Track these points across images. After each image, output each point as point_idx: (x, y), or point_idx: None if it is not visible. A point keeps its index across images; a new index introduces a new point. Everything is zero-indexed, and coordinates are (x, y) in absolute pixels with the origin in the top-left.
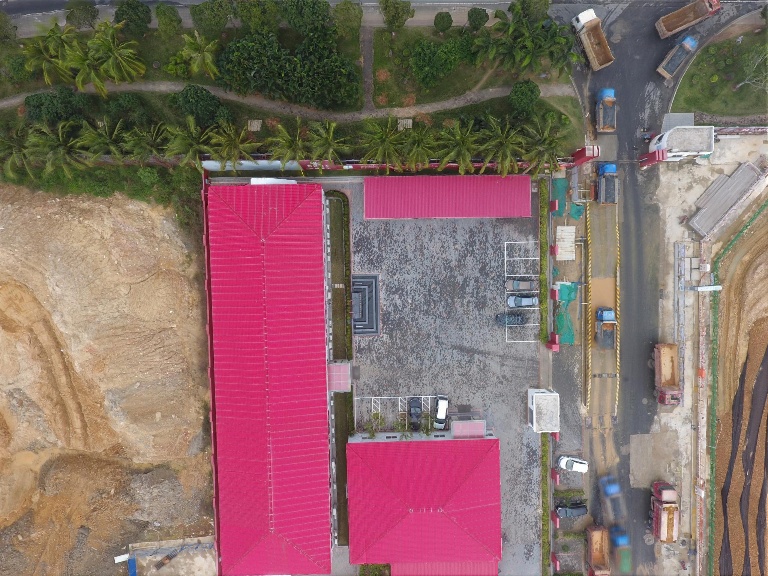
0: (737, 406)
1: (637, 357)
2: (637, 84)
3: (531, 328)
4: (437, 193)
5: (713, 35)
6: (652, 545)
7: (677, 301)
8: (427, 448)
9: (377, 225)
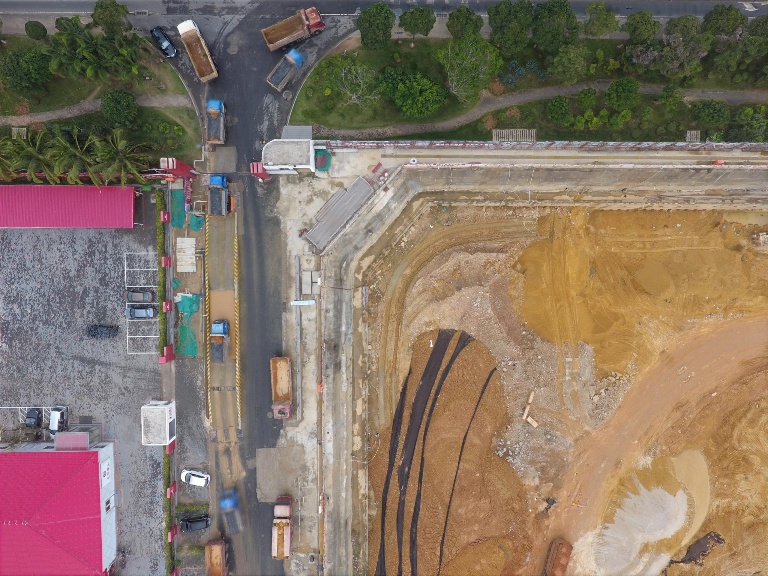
0: (397, 420)
1: (261, 370)
2: (255, 96)
3: (153, 340)
4: (39, 203)
5: (331, 48)
6: (281, 560)
7: (299, 315)
8: (24, 460)
9: None
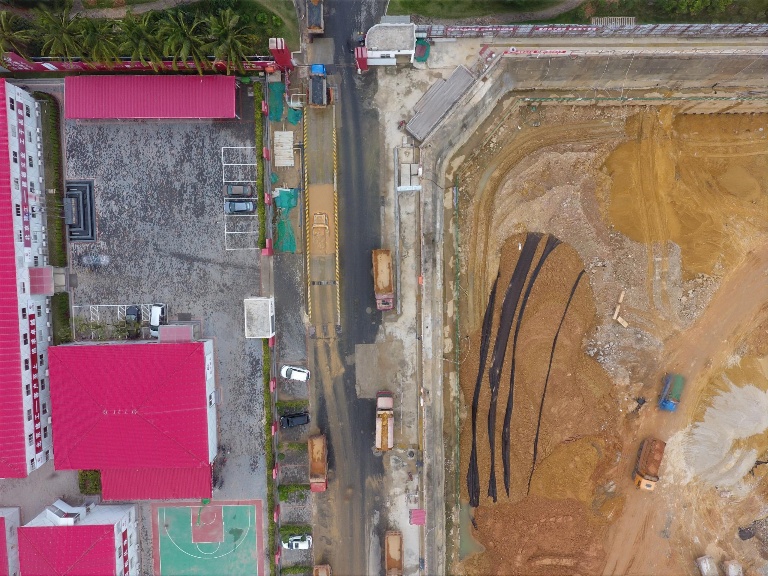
0: (486, 323)
1: (360, 265)
2: None
3: (251, 235)
4: (139, 93)
5: None
6: (380, 456)
7: (398, 208)
8: (129, 351)
9: (90, 129)
